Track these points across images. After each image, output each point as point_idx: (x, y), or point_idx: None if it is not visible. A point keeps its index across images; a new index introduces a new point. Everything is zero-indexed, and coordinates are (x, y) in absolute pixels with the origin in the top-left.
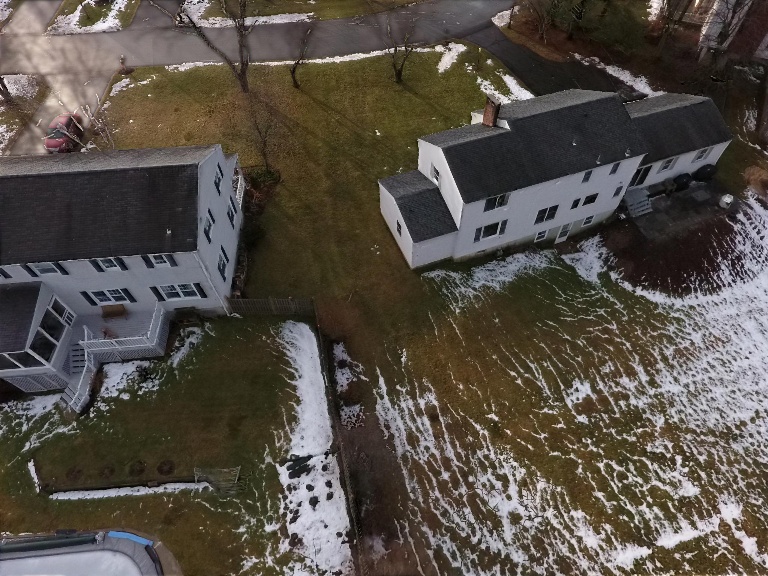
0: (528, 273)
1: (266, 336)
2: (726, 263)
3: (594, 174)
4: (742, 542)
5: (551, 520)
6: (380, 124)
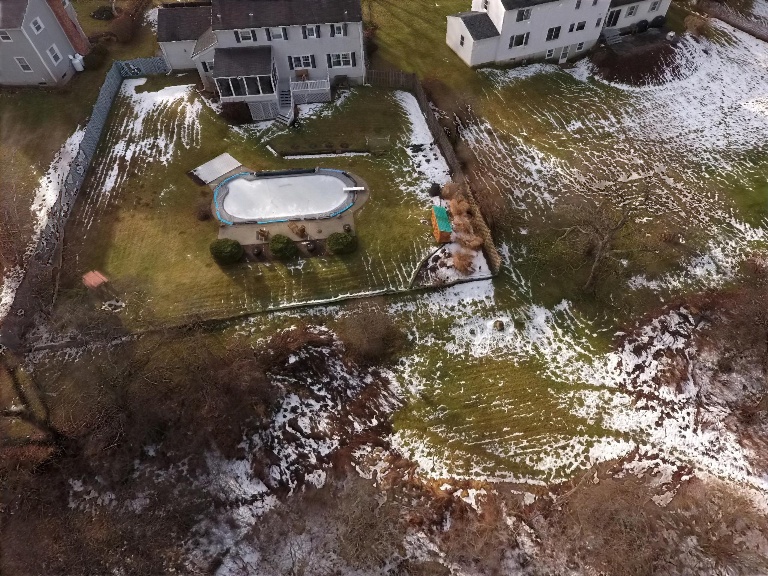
0: (542, 73)
1: (387, 96)
2: (669, 69)
3: (583, 2)
4: (665, 180)
5: (559, 172)
6: (438, 0)
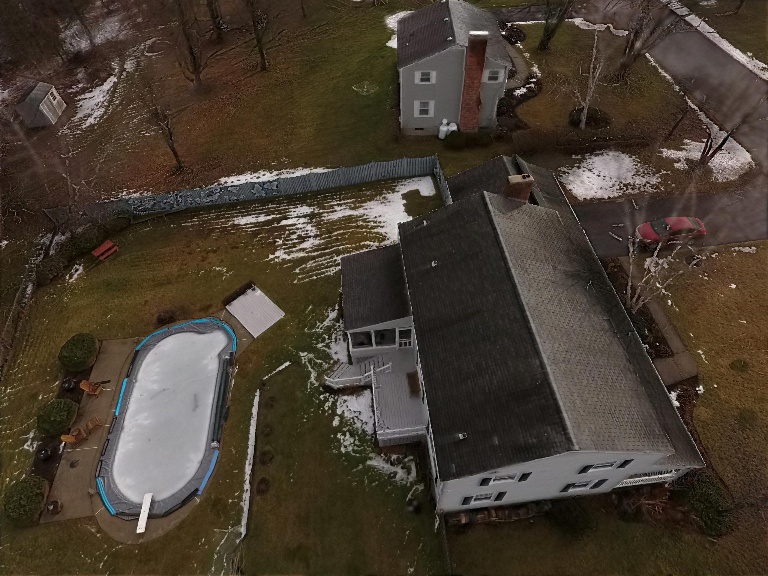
0: None
1: (414, 572)
2: None
3: None
4: None
5: None
6: None
